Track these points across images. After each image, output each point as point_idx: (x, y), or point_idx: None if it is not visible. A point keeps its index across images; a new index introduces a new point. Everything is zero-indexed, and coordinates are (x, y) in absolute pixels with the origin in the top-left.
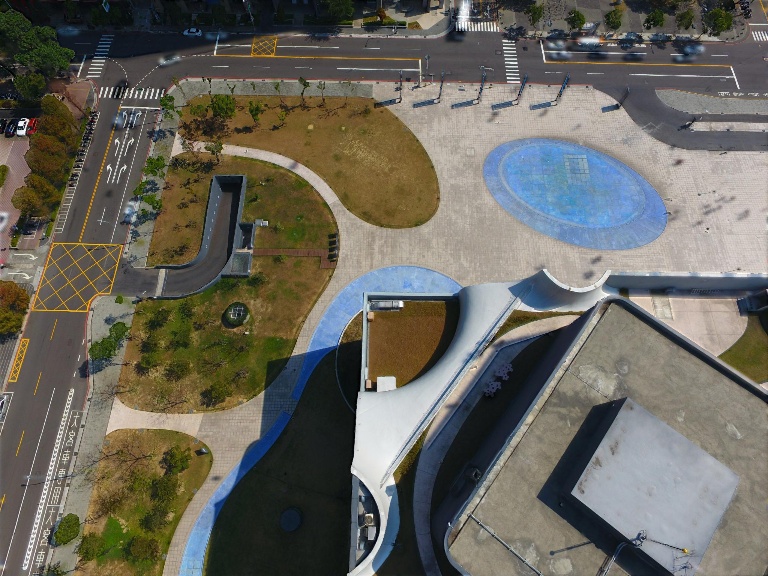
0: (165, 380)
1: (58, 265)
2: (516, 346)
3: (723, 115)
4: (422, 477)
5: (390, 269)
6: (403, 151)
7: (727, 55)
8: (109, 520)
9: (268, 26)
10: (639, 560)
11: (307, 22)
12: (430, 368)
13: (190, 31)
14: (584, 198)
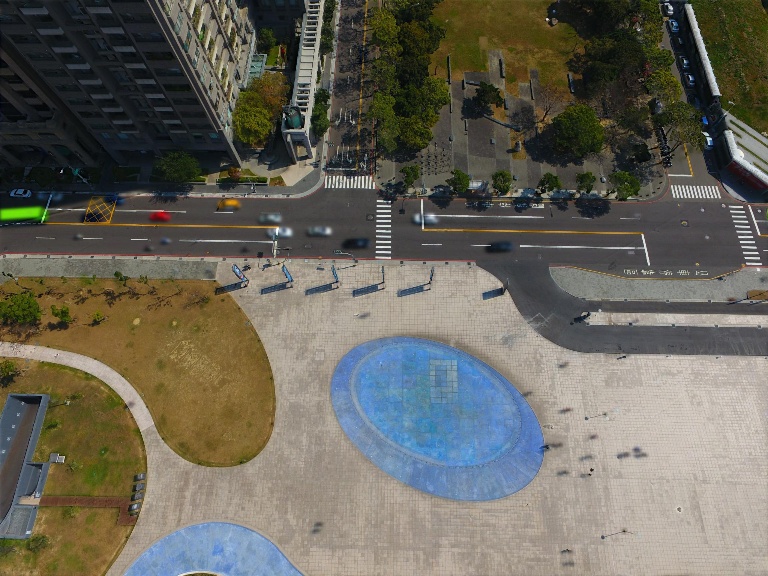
0: None
1: None
2: None
3: (626, 303)
4: None
5: (200, 527)
6: (240, 356)
7: (639, 218)
8: None
9: (109, 183)
10: None
11: (153, 179)
12: None
13: (16, 193)
14: (447, 422)
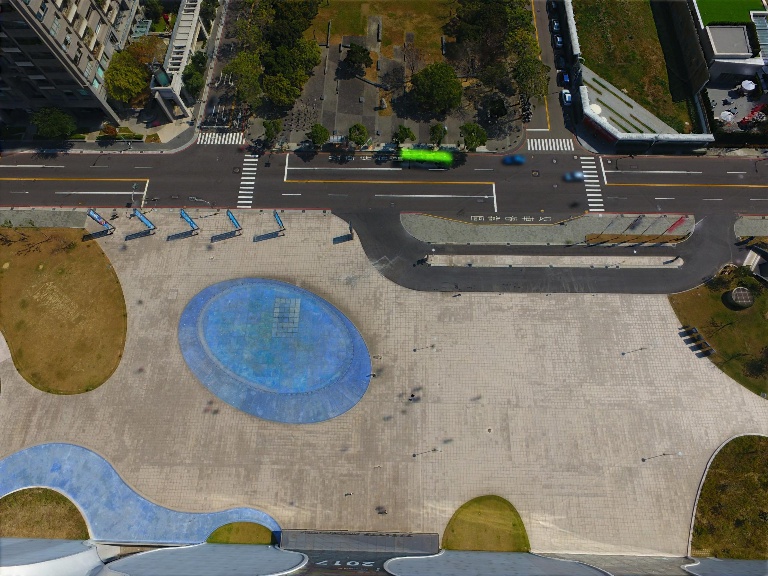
0: None
1: None
2: None
3: (469, 246)
4: None
5: (42, 447)
6: (98, 295)
7: (492, 169)
8: None
9: None
10: None
11: (36, 137)
12: None
13: None
14: (284, 354)
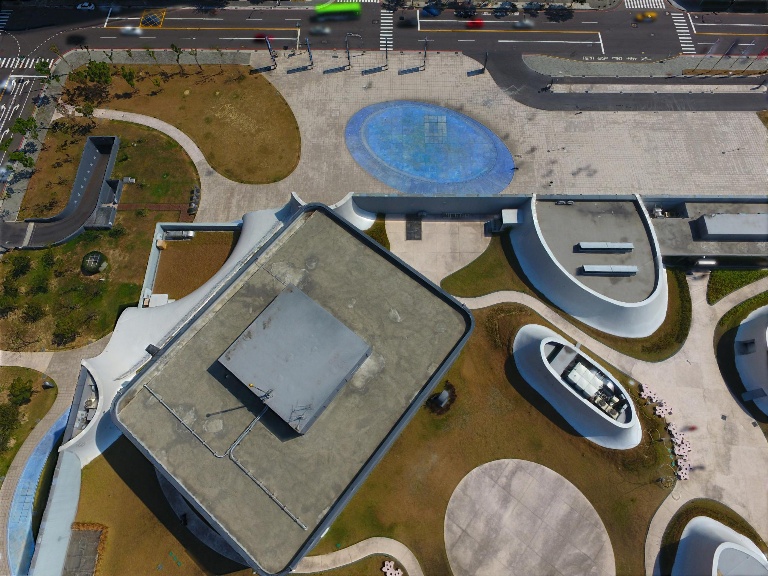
0: (22, 322)
1: None
2: None
3: (584, 78)
4: None
5: None
6: (271, 114)
7: (597, 22)
8: None
9: None
10: (283, 421)
11: None
12: None
13: (83, 5)
14: (438, 155)
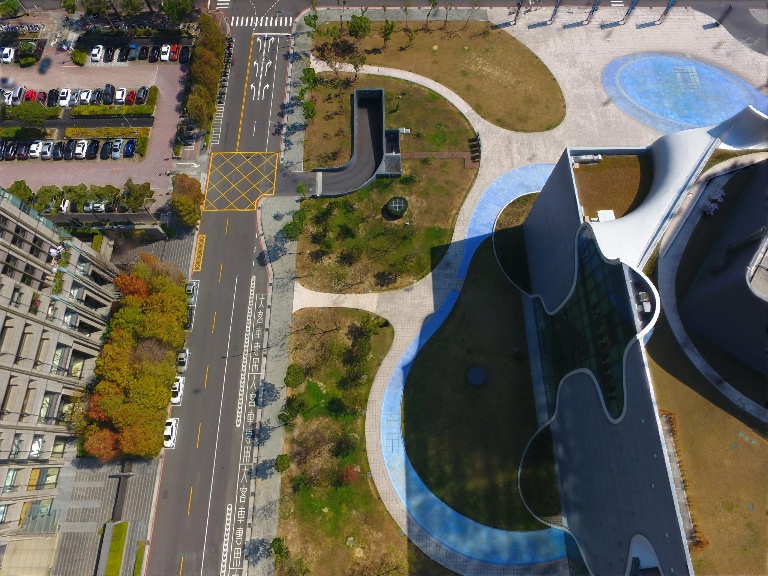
0: (339, 266)
1: (220, 171)
2: (723, 177)
3: None
4: (663, 278)
5: (530, 167)
6: (525, 66)
7: None
8: (308, 383)
9: None
10: None
11: None
12: (635, 208)
13: None
14: (698, 103)
